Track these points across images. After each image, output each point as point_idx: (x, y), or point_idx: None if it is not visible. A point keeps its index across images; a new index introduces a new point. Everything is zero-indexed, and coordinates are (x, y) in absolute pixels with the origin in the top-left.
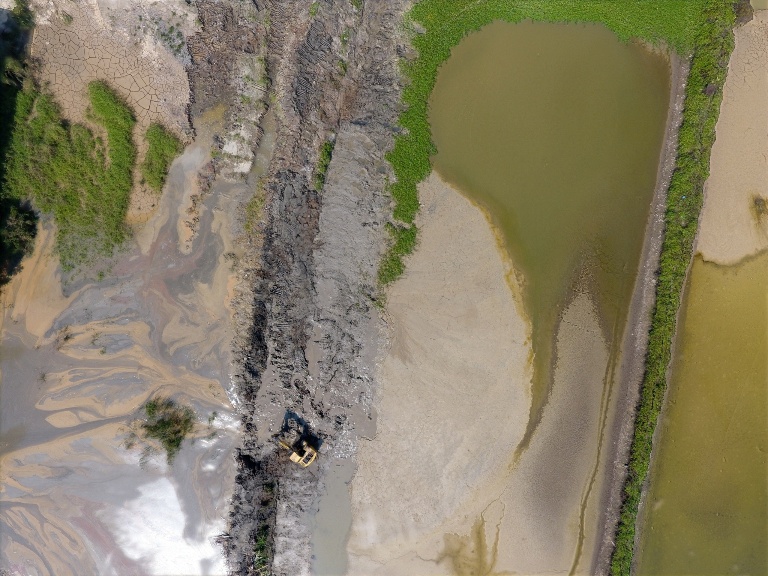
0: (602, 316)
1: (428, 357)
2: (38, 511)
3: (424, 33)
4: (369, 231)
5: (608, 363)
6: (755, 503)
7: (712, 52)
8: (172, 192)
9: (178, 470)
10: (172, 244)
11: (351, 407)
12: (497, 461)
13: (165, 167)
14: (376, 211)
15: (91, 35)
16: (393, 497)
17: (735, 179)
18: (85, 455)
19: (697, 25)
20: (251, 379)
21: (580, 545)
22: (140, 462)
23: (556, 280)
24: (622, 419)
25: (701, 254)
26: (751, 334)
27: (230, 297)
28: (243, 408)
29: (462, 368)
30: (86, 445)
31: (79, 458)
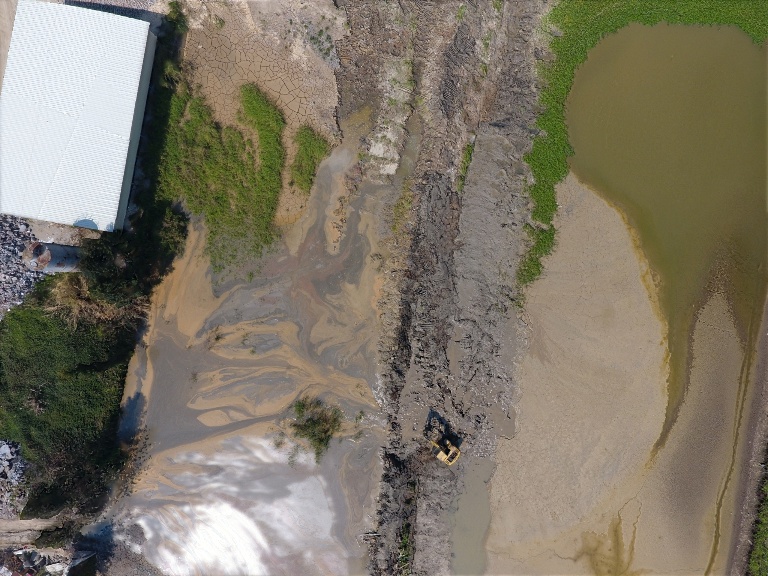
0: (737, 316)
1: (566, 357)
2: (190, 509)
3: (561, 36)
4: (508, 232)
5: (743, 363)
6: None
7: None
8: (320, 194)
9: (326, 468)
10: (320, 245)
11: (490, 406)
12: (634, 460)
13: (314, 169)
14: (514, 212)
15: (242, 39)
16: (531, 496)
17: None
18: (235, 454)
19: None
20: (397, 378)
21: (716, 543)
22: (289, 460)
23: (692, 280)
24: (757, 418)
25: None
26: None
27: (377, 297)
28: (389, 407)
29: (599, 368)
30: (236, 444)
31: (229, 456)
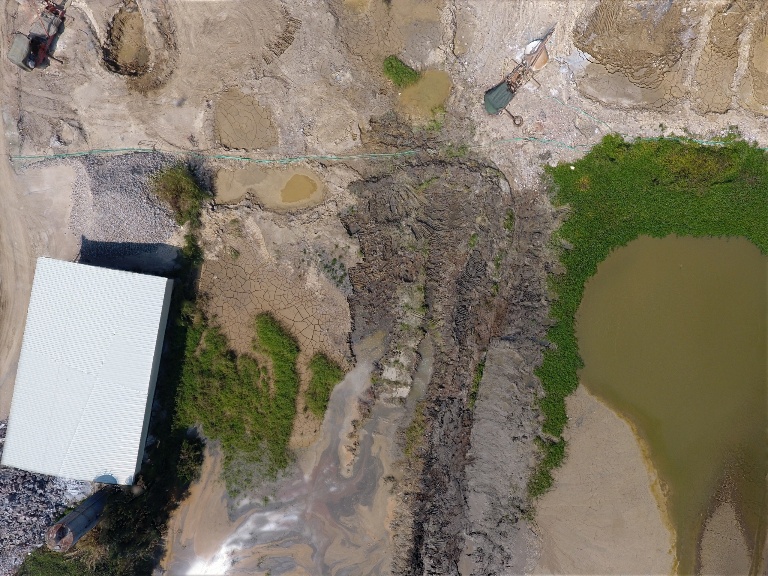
0: (744, 524)
1: (576, 567)
2: None
3: (571, 249)
4: (518, 445)
5: (750, 570)
6: None
7: None
8: (333, 417)
9: None
10: (333, 468)
11: None
12: None
13: (327, 394)
14: (525, 424)
15: (257, 269)
16: None
17: None
18: None
19: None
20: None
21: None
22: None
23: (700, 489)
24: None
25: None
26: None
27: (390, 519)
28: None
29: None
30: None
31: None
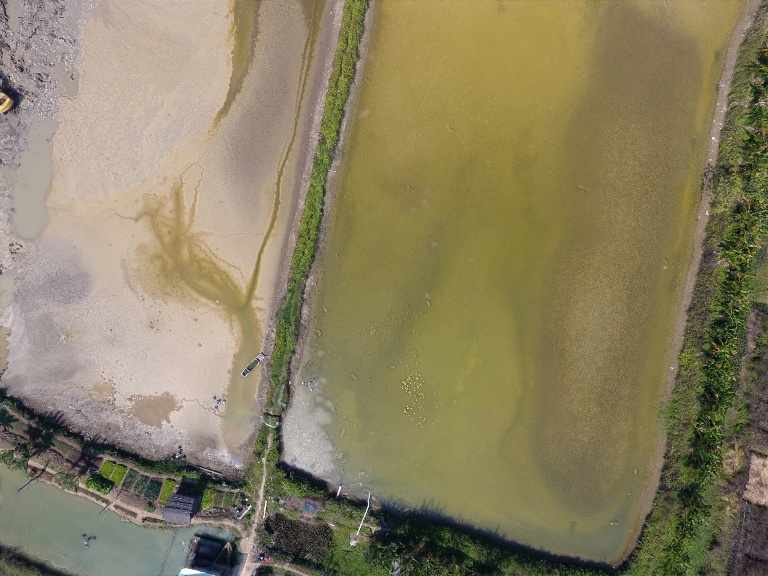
0: None
1: (131, 22)
2: None
3: None
4: None
5: (307, 39)
6: (445, 179)
7: None
8: None
9: None
10: None
11: (53, 66)
12: (197, 126)
13: None
14: None
15: None
16: (93, 155)
17: None
18: None
19: None
20: None
21: (276, 210)
22: None
23: None
24: (319, 92)
25: None
26: (445, 19)
27: None
28: None
29: (164, 35)
30: None
31: None
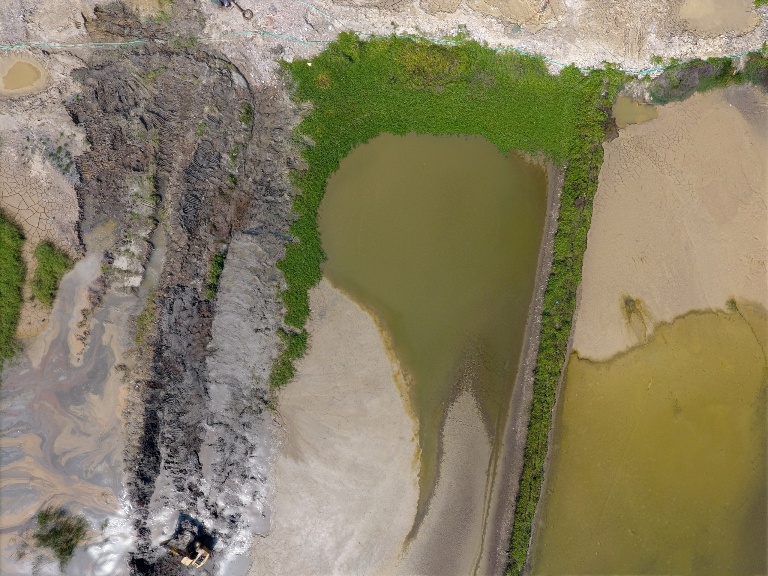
0: (485, 412)
1: (319, 456)
2: None
3: (313, 146)
4: (261, 337)
5: (491, 456)
6: None
7: (582, 167)
8: (63, 306)
9: None
10: (63, 357)
11: (245, 506)
12: (387, 552)
13: (55, 283)
14: (268, 317)
15: None
16: None
17: (607, 282)
18: None
19: (570, 139)
20: (144, 485)
21: None
22: (33, 570)
23: (441, 379)
24: (504, 508)
25: (576, 352)
26: (623, 425)
27: (122, 407)
28: (136, 514)
29: (352, 465)
30: None
31: None
